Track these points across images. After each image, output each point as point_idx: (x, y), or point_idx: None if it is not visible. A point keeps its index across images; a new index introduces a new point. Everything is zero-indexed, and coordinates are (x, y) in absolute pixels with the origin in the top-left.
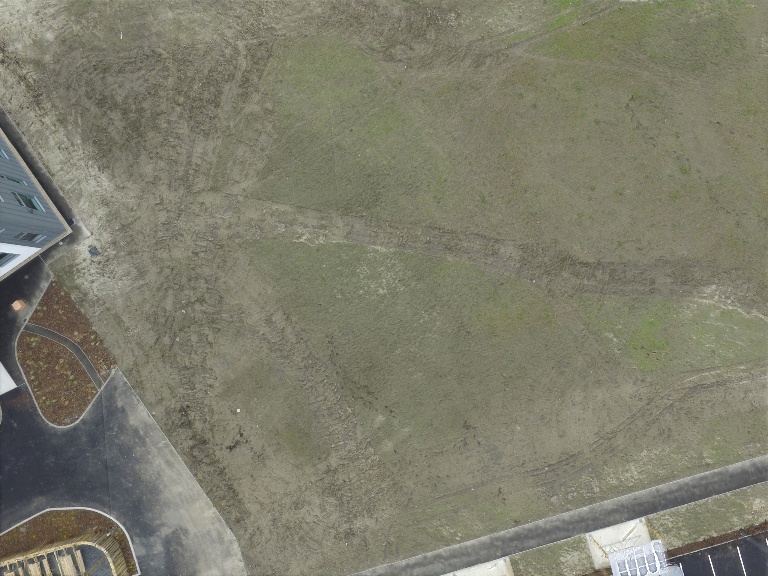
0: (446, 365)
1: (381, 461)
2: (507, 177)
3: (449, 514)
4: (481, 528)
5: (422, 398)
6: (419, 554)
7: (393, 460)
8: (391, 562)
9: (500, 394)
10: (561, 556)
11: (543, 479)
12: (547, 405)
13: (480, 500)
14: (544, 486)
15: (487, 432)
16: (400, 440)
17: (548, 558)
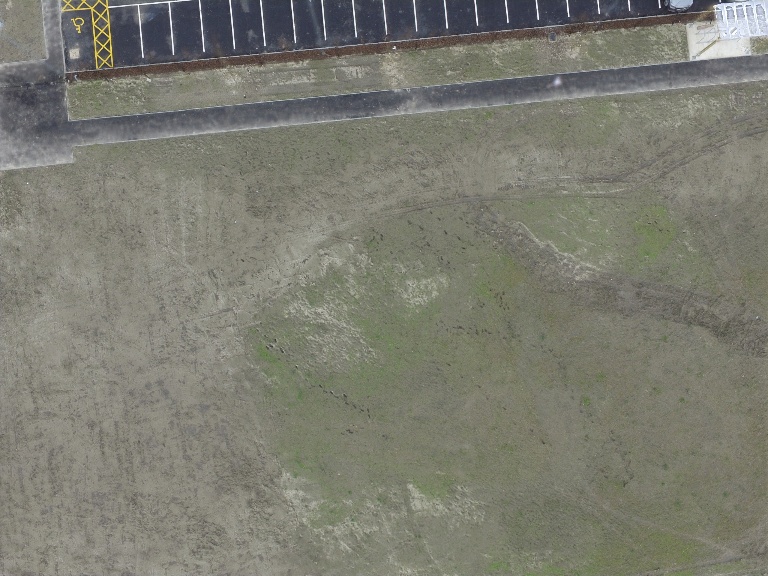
0: None
1: None
2: (765, 428)
3: None
4: None
5: None
6: None
7: None
8: None
9: None
10: None
11: None
12: (766, 191)
13: None
14: None
15: None
16: None
17: None
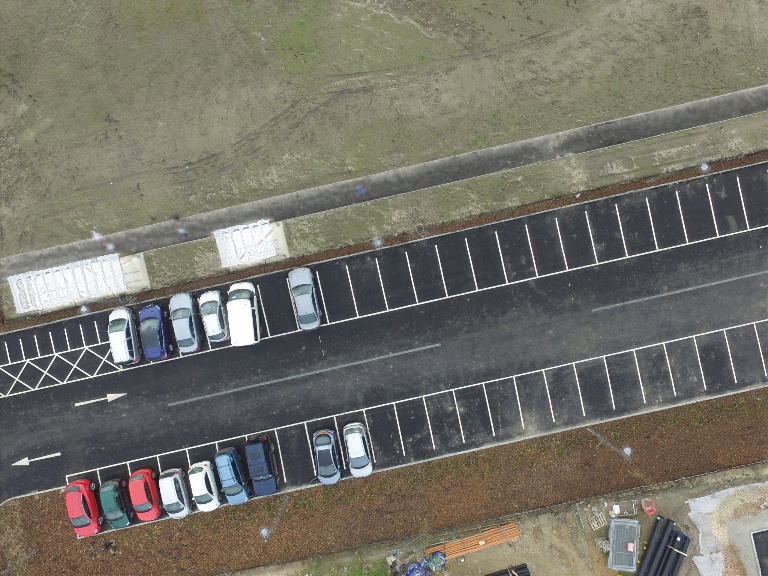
0: (92, 57)
1: (22, 150)
2: None
3: (86, 207)
4: (117, 223)
5: (66, 89)
6: (54, 246)
7: (34, 150)
8: (25, 252)
9: (144, 89)
10: (195, 255)
11: (183, 177)
12: (191, 102)
13: (118, 195)
14: (183, 184)
15: (129, 126)
16: (42, 130)
17: (182, 257)
